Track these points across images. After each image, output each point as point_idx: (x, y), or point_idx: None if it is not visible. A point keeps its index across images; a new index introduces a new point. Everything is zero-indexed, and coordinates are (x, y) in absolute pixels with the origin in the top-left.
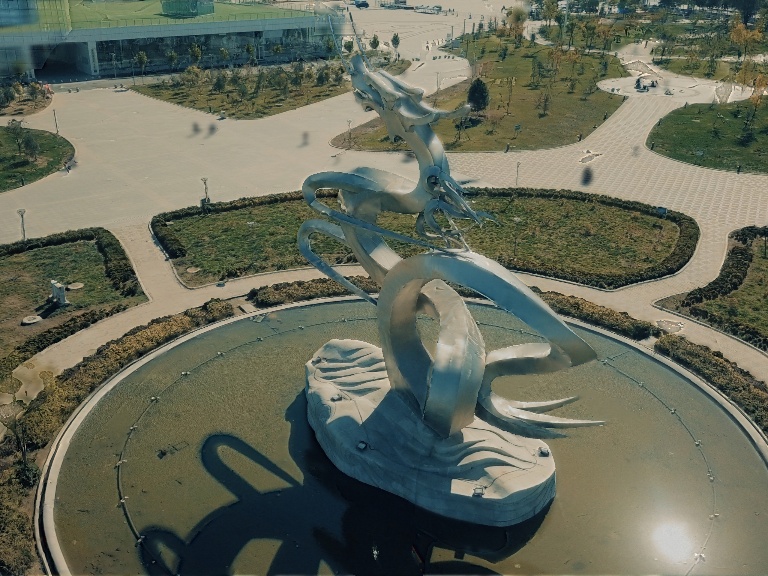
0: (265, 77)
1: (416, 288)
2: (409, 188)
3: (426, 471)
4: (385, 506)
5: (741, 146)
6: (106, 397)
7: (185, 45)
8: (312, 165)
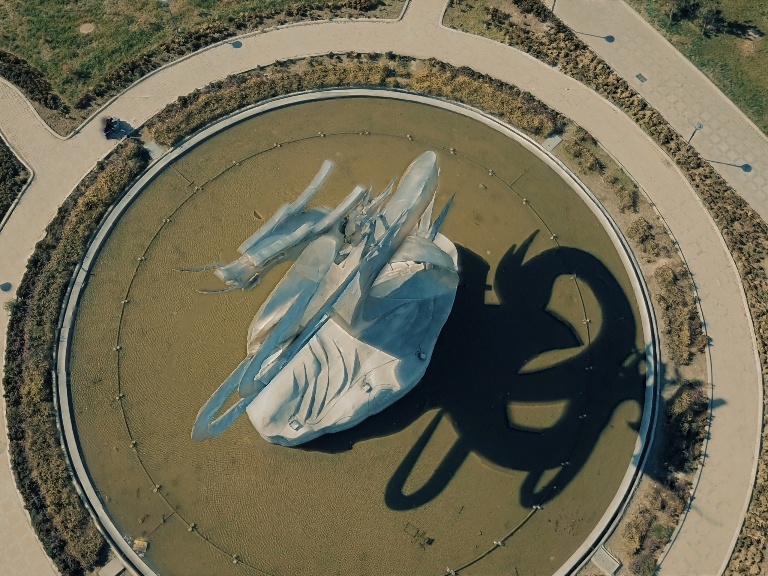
0: None
1: None
2: (317, 258)
3: (434, 308)
4: None
5: None
6: None
7: None
8: None
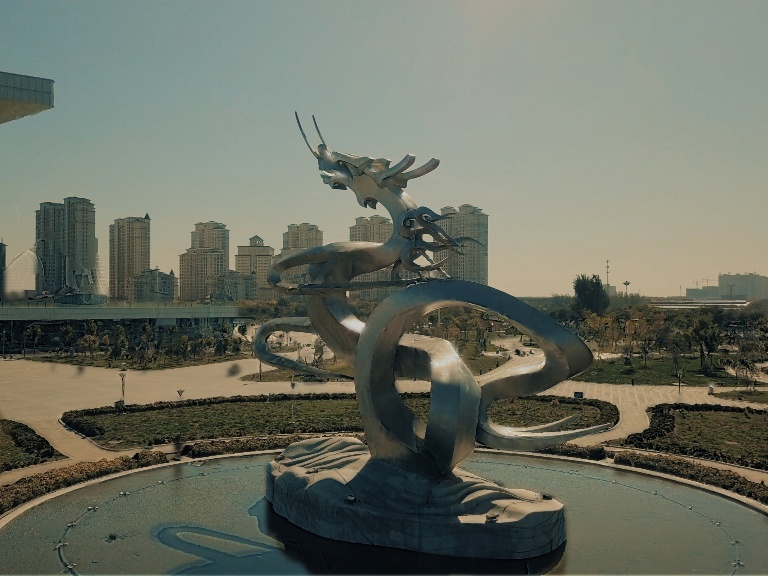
0: (163, 345)
1: (395, 338)
2: None
3: (427, 514)
4: (381, 569)
5: (627, 374)
6: (33, 510)
7: (81, 321)
8: (225, 388)
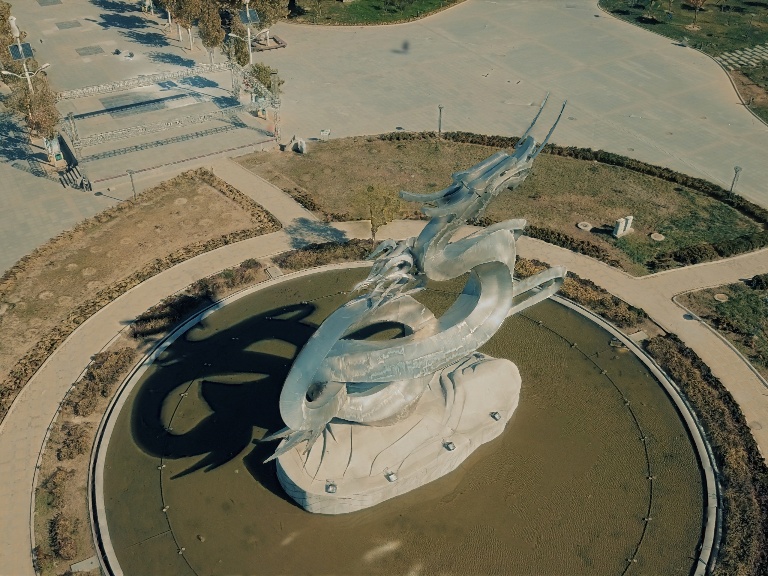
0: None
1: None
2: (445, 254)
3: None
4: None
5: None
6: (467, 273)
7: None
8: None
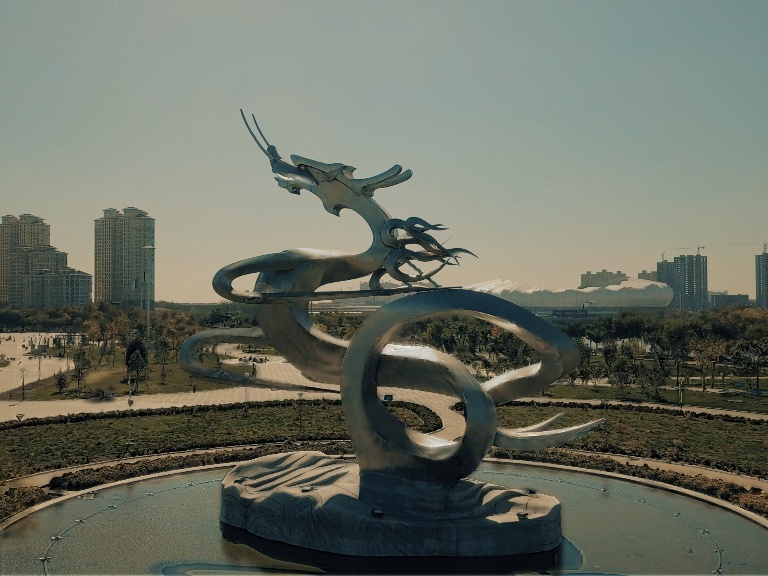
0: None
1: (380, 347)
2: None
3: (455, 519)
4: None
5: None
6: None
7: None
8: None
